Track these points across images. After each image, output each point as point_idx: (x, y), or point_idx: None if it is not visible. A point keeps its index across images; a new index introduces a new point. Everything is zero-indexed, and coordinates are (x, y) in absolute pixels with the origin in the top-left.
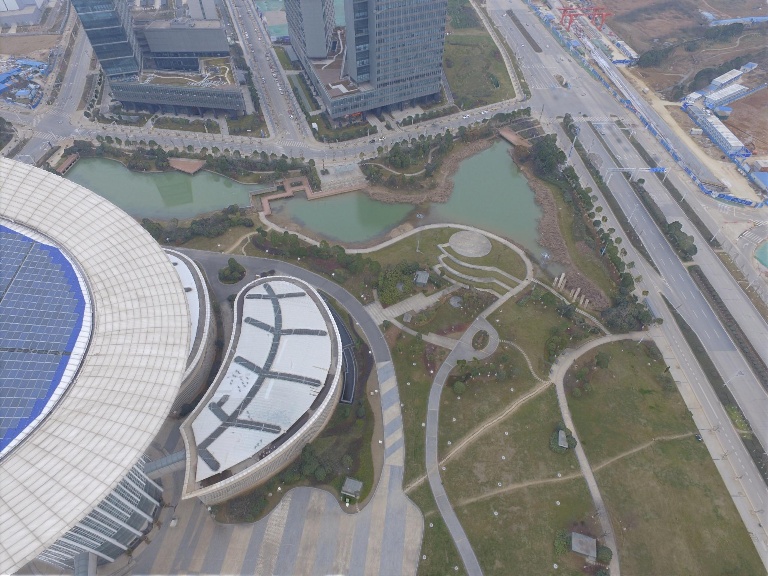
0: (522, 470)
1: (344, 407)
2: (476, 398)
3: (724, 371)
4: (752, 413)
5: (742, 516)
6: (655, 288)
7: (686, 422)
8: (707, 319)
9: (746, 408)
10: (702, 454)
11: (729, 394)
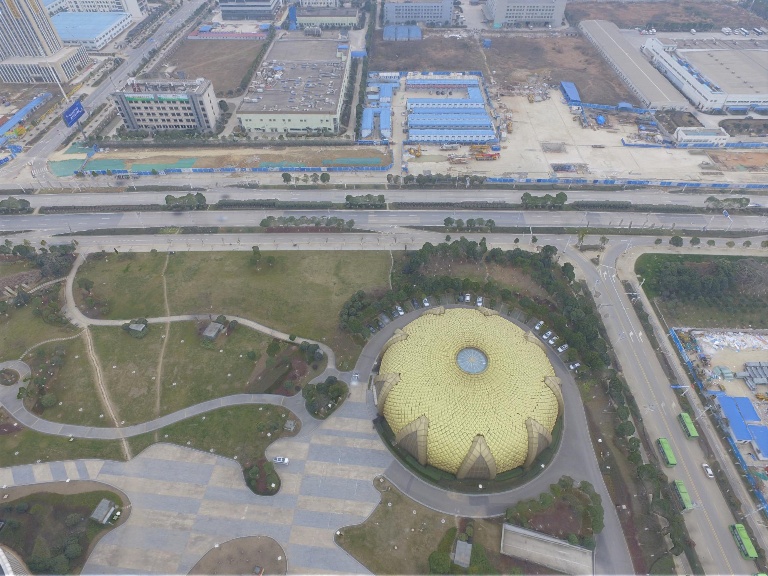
0: (149, 360)
1: (5, 531)
2: (69, 388)
3: (135, 225)
4: (169, 223)
5: (224, 250)
6: (44, 238)
7: (159, 255)
8: (91, 219)
9: (164, 224)
10: (183, 255)
11: (151, 228)
